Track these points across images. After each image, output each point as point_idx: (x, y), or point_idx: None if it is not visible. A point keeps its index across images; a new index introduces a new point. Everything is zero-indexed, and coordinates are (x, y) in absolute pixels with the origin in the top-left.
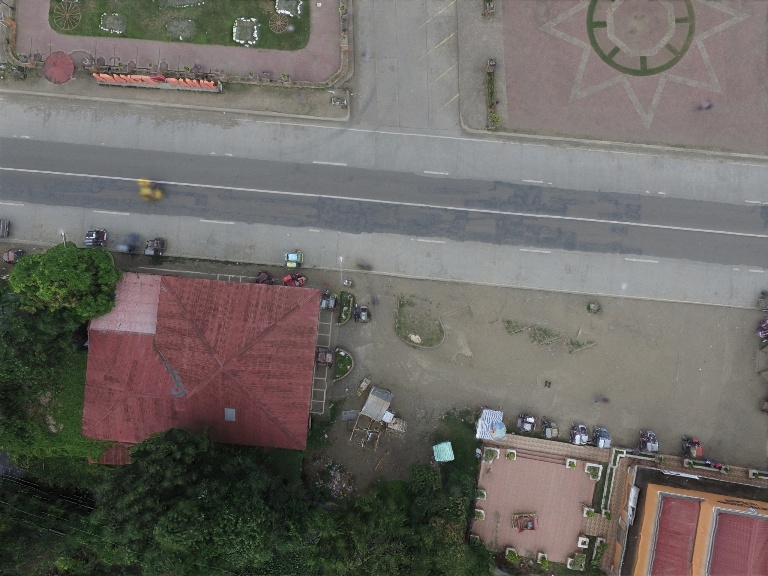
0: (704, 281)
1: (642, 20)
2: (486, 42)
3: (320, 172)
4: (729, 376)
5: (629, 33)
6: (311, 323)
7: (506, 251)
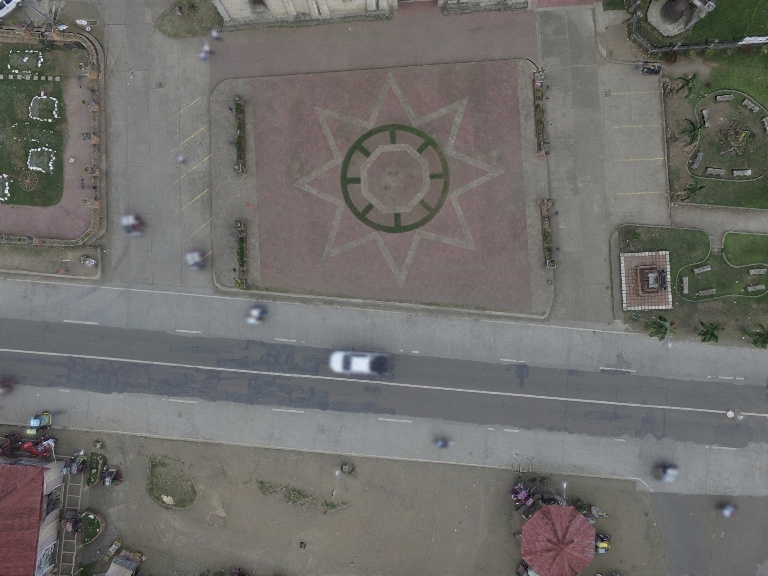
0: (459, 441)
1: (396, 176)
2: (239, 198)
3: (71, 331)
4: (485, 537)
5: (383, 189)
6: (32, 503)
7: (259, 411)
